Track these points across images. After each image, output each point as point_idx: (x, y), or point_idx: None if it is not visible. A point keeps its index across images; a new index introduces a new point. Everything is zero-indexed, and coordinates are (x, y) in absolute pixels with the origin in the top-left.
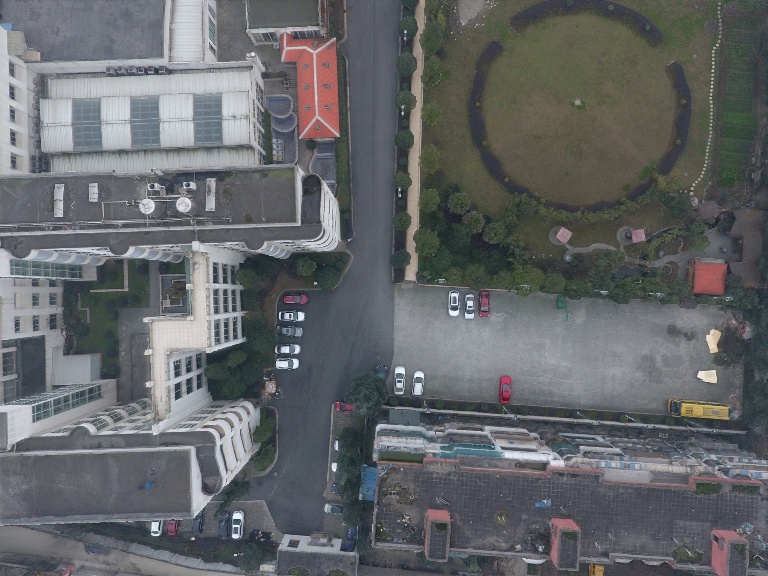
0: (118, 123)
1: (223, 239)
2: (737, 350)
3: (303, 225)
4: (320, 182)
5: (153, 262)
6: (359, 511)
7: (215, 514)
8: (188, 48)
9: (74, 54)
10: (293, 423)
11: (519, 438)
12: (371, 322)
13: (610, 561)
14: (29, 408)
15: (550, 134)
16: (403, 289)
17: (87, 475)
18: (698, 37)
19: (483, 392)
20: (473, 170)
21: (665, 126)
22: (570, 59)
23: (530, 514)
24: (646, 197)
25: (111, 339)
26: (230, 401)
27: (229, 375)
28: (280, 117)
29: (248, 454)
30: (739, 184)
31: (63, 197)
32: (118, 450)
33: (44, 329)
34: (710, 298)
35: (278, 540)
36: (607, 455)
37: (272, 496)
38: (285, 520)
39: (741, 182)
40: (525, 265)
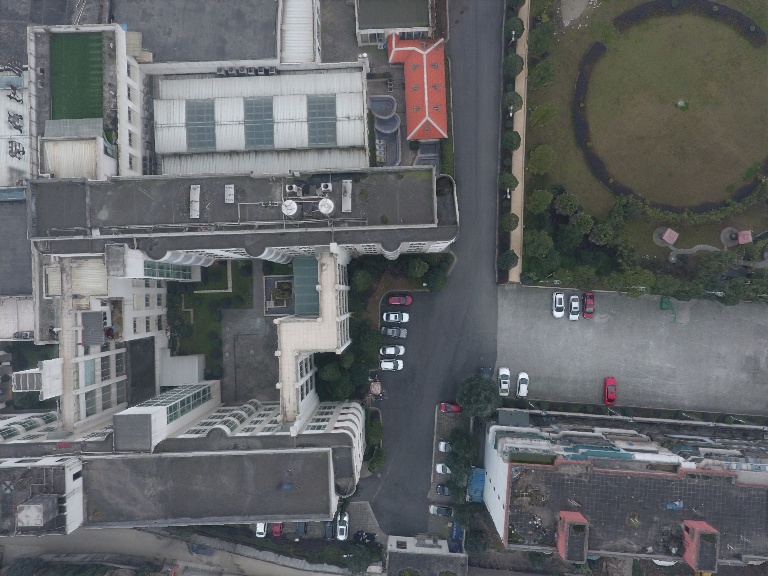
0: (232, 124)
1: (359, 240)
2: None
3: (439, 226)
4: (452, 183)
5: (256, 263)
6: (471, 512)
7: (340, 515)
8: (299, 49)
9: (186, 55)
10: (397, 424)
11: (635, 440)
12: (475, 323)
13: (744, 563)
14: (165, 409)
15: (653, 135)
16: (506, 290)
17: (223, 476)
18: None
19: (587, 393)
20: (576, 171)
21: None
22: (673, 60)
23: (662, 516)
24: (753, 198)
25: (216, 340)
26: (337, 402)
27: (341, 376)
28: (383, 118)
29: (362, 455)
30: None
31: (199, 198)
32: (256, 452)
33: (154, 330)
34: None
35: (382, 541)
36: (729, 457)
37: (376, 497)
38: (389, 521)
39: None
40: (633, 266)
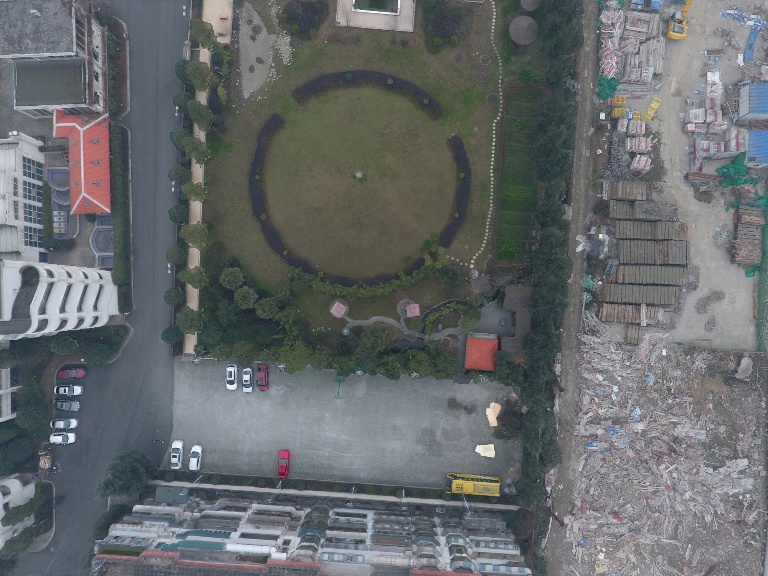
0: None
1: None
2: (515, 424)
3: (13, 320)
4: (38, 274)
5: None
6: None
7: None
8: None
9: None
10: (70, 498)
11: (273, 520)
12: (150, 395)
13: None
14: None
15: (331, 207)
16: (183, 362)
17: None
18: (479, 110)
19: (262, 466)
20: (254, 243)
21: (446, 199)
22: (352, 132)
23: None
24: (421, 271)
25: None
26: None
27: None
28: (61, 190)
29: (2, 536)
30: (519, 257)
31: None
32: None
33: None
34: (475, 376)
35: None
36: (348, 542)
37: (48, 572)
38: None
39: (521, 255)
40: (297, 340)
